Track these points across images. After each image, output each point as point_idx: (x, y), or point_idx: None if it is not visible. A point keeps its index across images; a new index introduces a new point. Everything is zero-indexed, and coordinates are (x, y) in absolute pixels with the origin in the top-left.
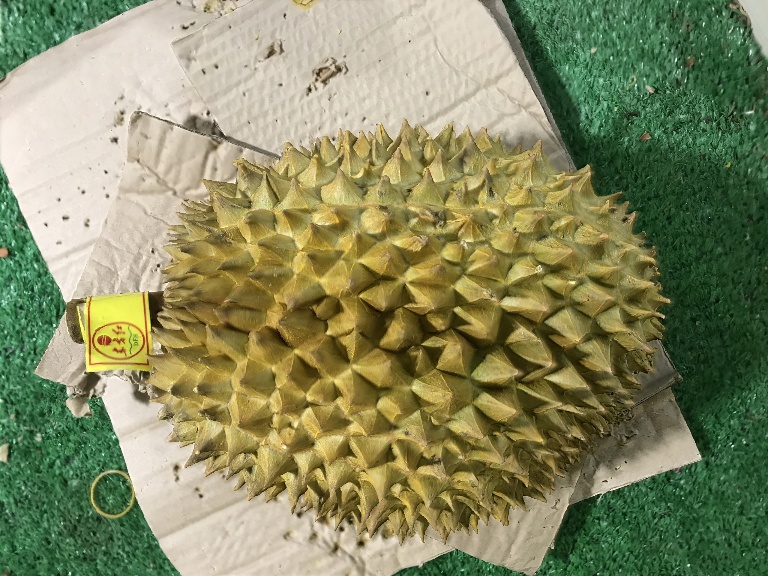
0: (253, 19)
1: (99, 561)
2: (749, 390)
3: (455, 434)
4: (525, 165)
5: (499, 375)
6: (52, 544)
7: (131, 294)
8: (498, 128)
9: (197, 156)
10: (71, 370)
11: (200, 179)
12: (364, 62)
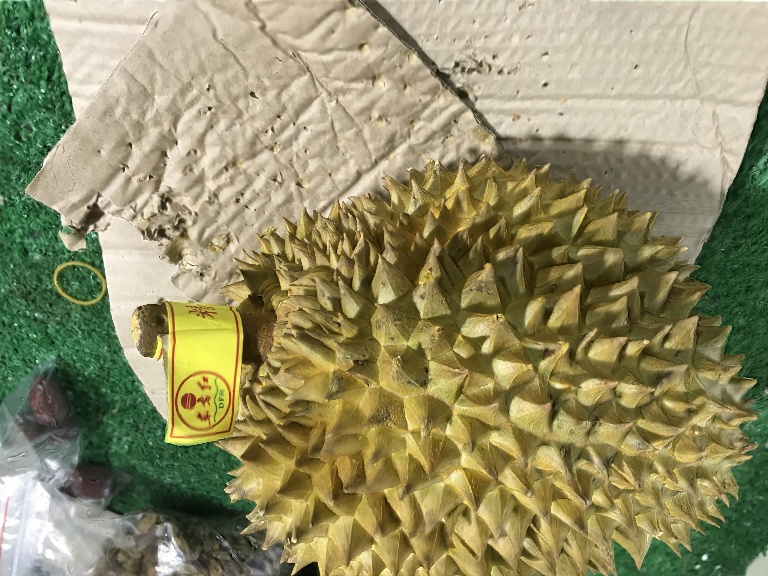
0: None
1: (51, 327)
2: None
3: None
4: (714, 410)
5: None
6: (0, 297)
7: (224, 329)
8: (679, 151)
9: (317, 7)
10: (71, 199)
11: (377, 305)
12: None
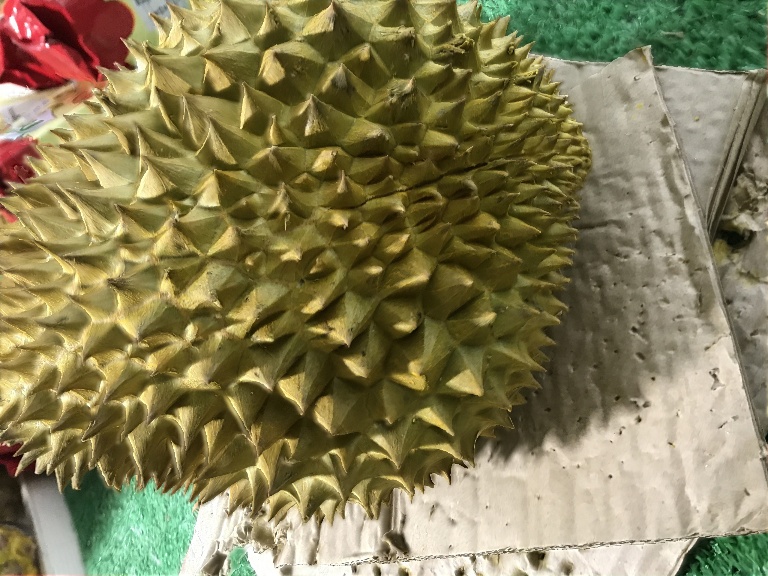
0: None
1: None
2: None
3: (123, 236)
4: None
5: None
6: None
7: None
8: None
9: None
10: (203, 559)
11: None
12: None
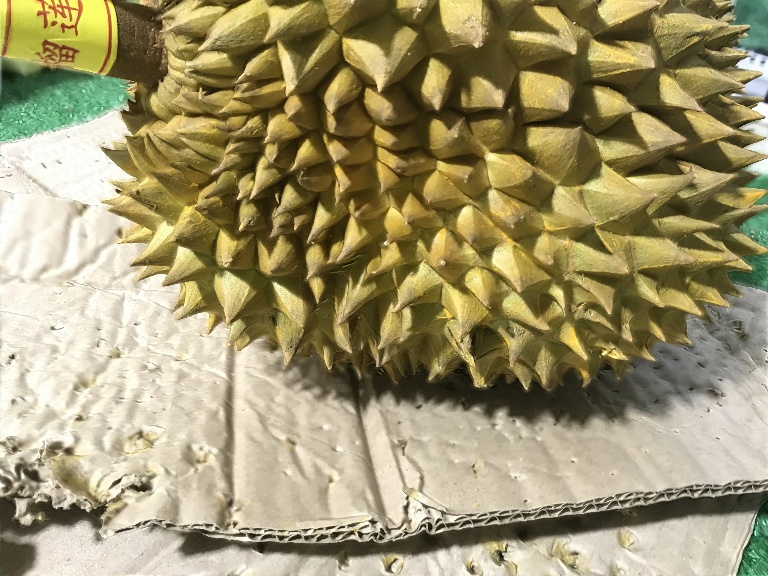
0: (94, 132)
1: None
2: (767, 269)
3: None
4: None
5: None
6: None
7: None
8: None
9: (55, 224)
10: None
11: None
12: None
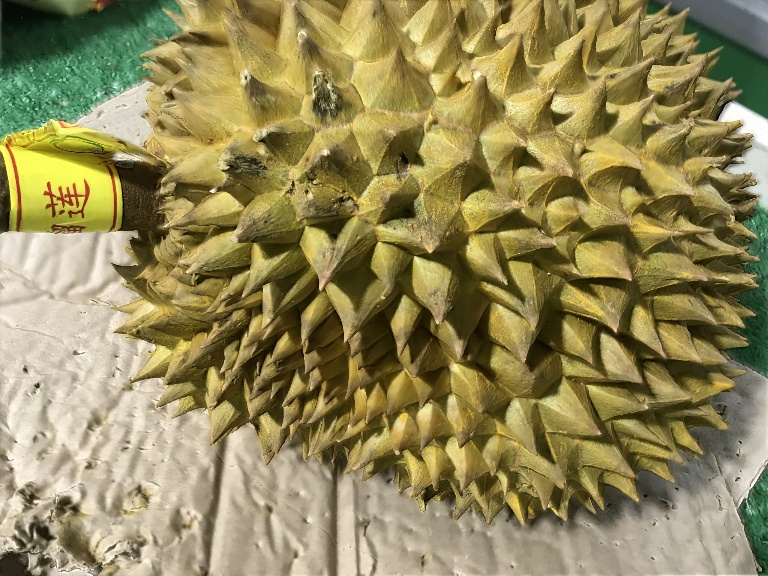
0: (130, 121)
1: None
2: None
3: (659, 93)
4: None
5: (654, 43)
6: None
7: None
8: None
9: (84, 239)
10: None
11: None
12: None
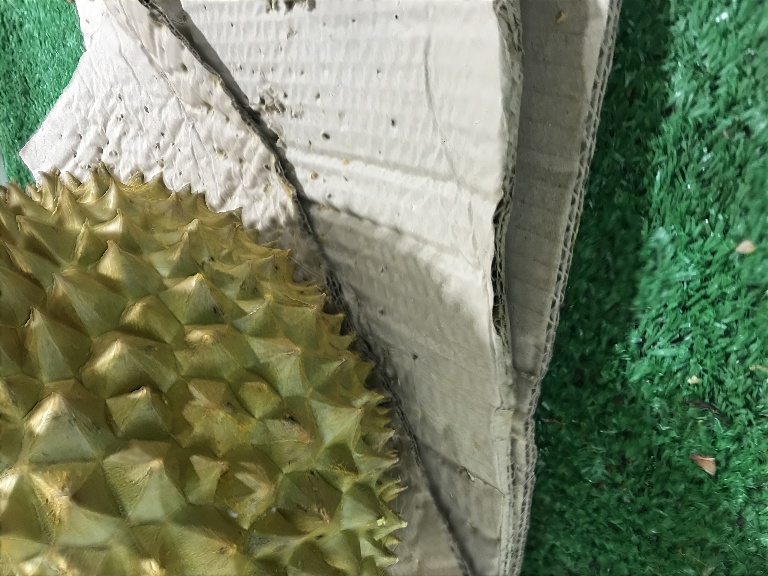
0: None
1: None
2: None
3: None
4: None
5: None
6: None
7: None
8: (444, 261)
9: (144, 22)
10: (42, 169)
11: None
12: (335, 7)
